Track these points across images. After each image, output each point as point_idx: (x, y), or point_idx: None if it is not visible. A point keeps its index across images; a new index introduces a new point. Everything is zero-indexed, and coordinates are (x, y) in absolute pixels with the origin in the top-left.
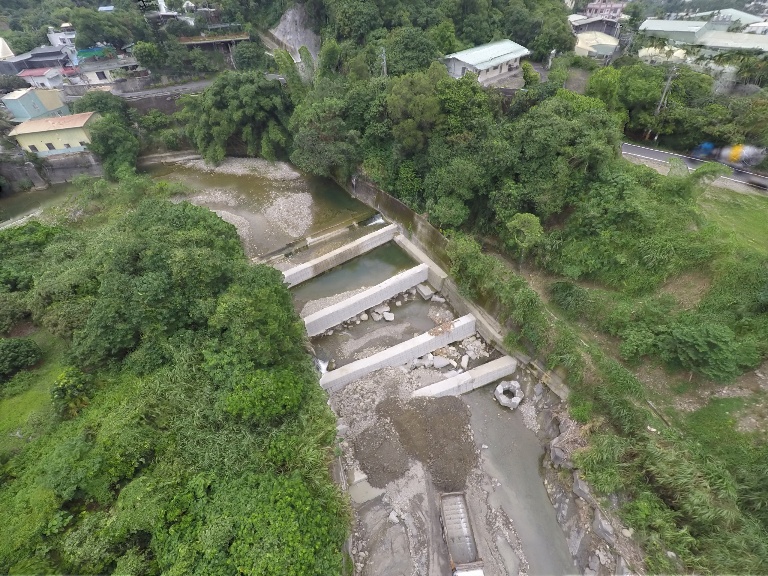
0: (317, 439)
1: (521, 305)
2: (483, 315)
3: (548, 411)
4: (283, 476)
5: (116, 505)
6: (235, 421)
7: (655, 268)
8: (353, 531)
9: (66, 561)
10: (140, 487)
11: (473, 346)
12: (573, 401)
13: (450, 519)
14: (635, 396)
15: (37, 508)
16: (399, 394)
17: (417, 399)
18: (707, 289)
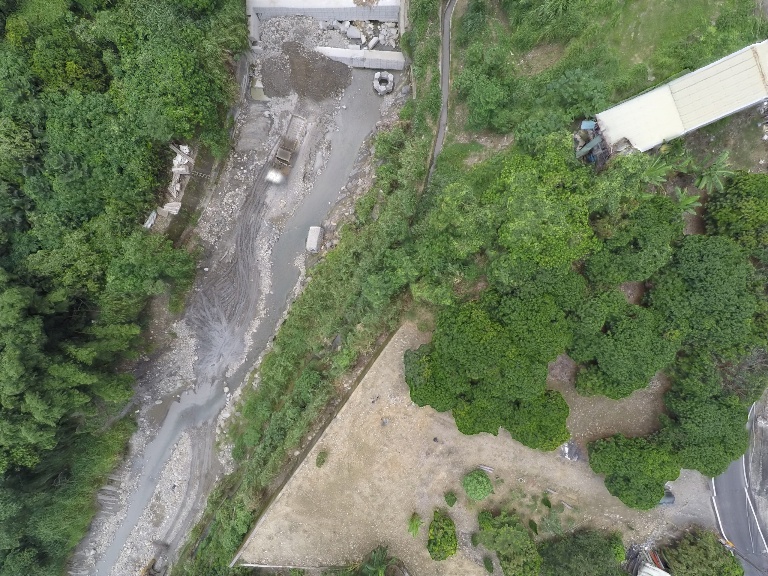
0: (220, 41)
1: (414, 5)
2: (406, 4)
3: (396, 105)
4: (185, 50)
5: (96, 21)
6: (168, 2)
7: (543, 23)
8: (242, 109)
9: (77, 38)
10: (106, 16)
11: (388, 32)
12: (406, 104)
13: (293, 128)
14: (430, 115)
15: (56, 2)
16: (304, 42)
17: (314, 53)
18: (551, 63)
